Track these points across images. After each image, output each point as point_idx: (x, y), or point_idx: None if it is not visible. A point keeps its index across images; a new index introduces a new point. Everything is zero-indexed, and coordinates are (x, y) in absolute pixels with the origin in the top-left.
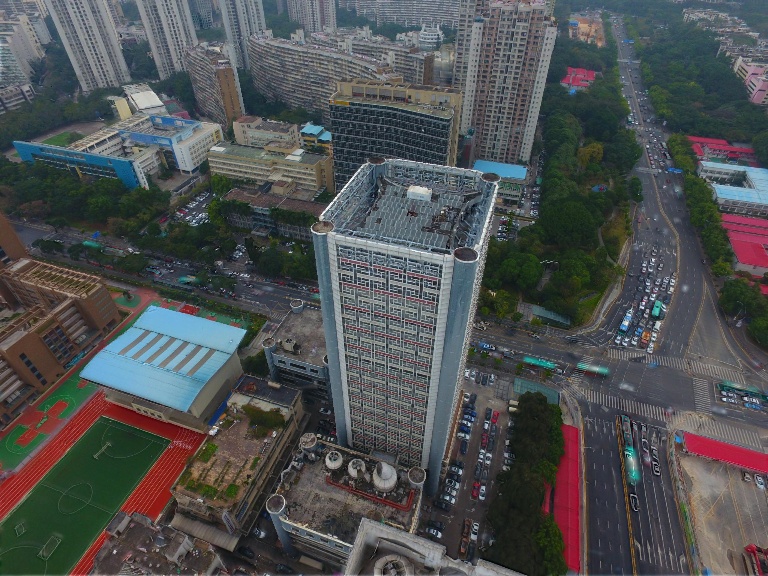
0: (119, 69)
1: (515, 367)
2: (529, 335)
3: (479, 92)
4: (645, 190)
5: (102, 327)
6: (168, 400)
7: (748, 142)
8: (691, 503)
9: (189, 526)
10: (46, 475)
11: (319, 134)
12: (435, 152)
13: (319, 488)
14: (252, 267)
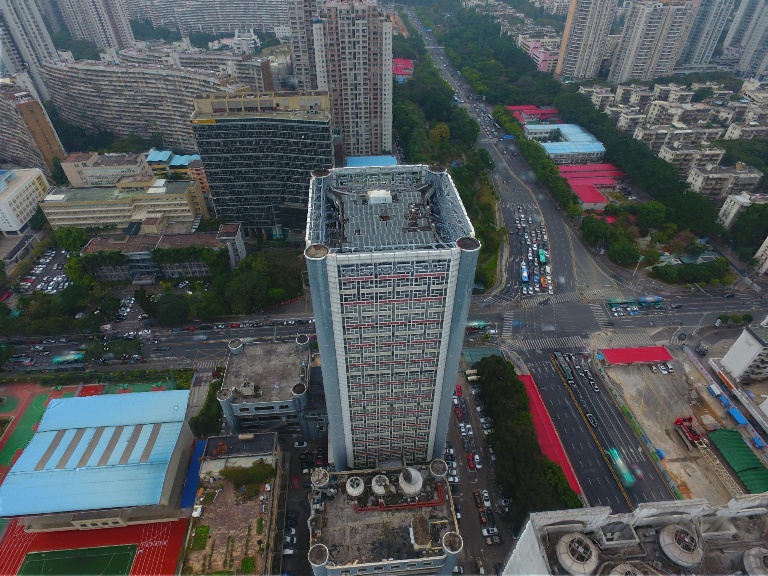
0: None
1: None
2: None
3: (332, 91)
4: (493, 158)
5: None
6: (129, 499)
7: (551, 104)
8: (628, 404)
9: None
10: None
11: (169, 160)
12: (320, 156)
13: (351, 520)
14: (150, 321)
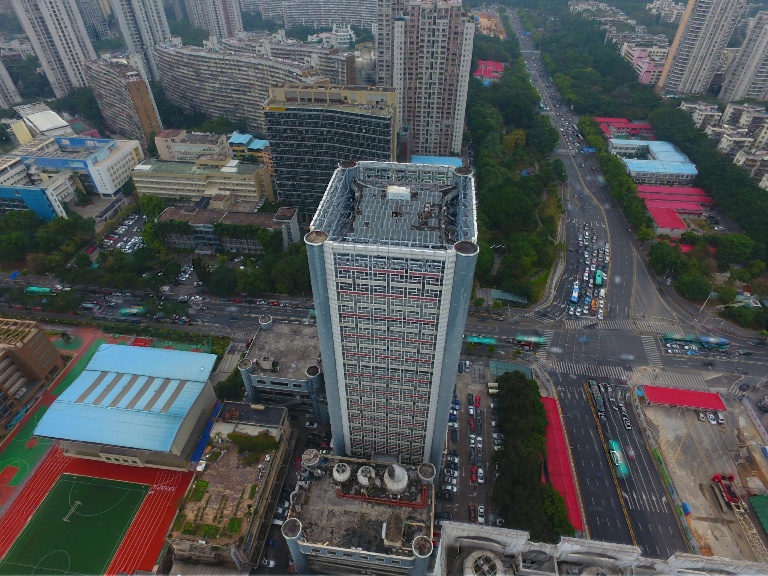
0: (5, 89)
1: (486, 351)
2: (492, 318)
3: (407, 89)
4: (568, 170)
5: (44, 376)
6: (145, 442)
7: (645, 119)
8: (662, 449)
9: (191, 572)
10: (9, 551)
11: (248, 143)
12: (378, 151)
13: (331, 503)
14: (203, 288)
